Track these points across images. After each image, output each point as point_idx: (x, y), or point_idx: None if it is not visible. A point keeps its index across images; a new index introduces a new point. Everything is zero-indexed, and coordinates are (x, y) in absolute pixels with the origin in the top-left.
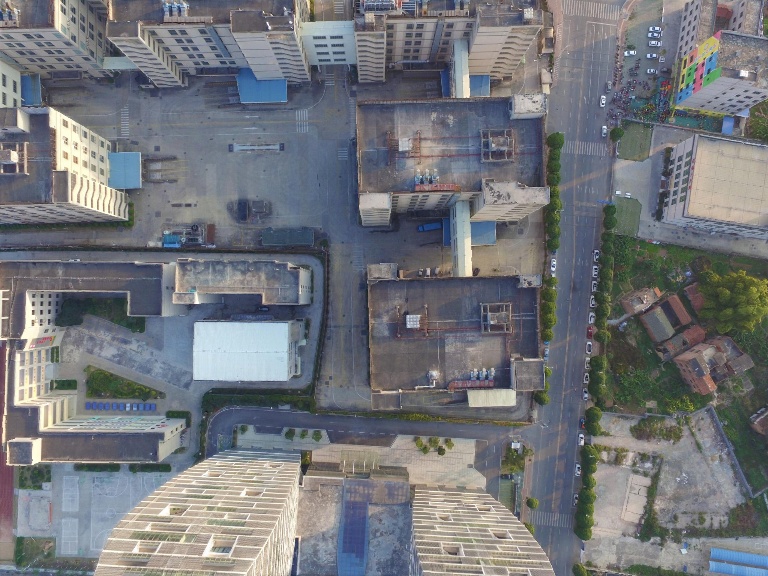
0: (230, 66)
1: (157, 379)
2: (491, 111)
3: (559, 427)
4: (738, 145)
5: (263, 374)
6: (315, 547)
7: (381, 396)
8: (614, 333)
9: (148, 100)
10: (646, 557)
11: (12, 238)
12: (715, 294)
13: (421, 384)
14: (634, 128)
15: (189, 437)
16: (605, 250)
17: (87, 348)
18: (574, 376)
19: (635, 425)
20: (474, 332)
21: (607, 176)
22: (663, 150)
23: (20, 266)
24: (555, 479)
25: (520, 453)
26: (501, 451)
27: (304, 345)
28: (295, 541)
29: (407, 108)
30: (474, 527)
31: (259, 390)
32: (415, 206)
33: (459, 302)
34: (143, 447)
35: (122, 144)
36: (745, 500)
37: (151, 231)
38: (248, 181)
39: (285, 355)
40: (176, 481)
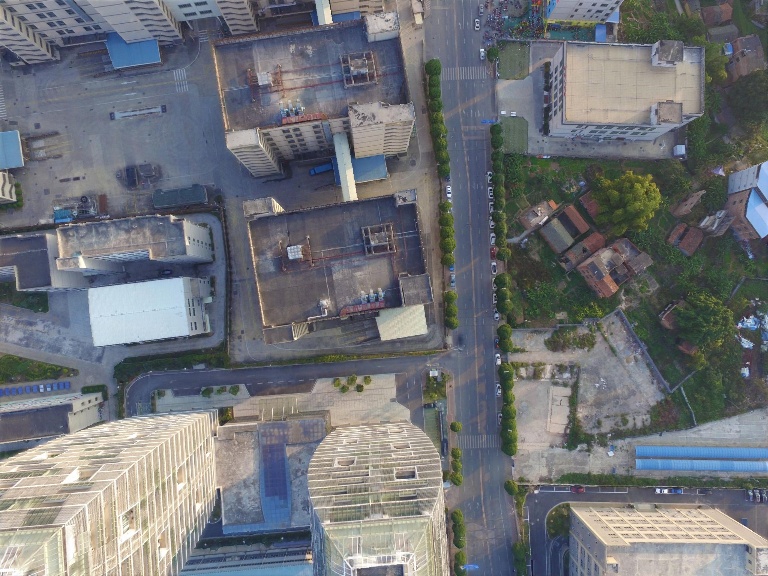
0: (97, 32)
1: (68, 357)
2: (349, 37)
3: (475, 350)
4: (607, 47)
5: (164, 331)
6: (238, 495)
7: (273, 330)
8: (516, 250)
9: (22, 78)
10: (575, 465)
11: None
12: (608, 199)
13: (313, 315)
14: (511, 47)
15: (108, 410)
16: (495, 169)
17: None
18: (483, 298)
19: (549, 338)
20: (359, 256)
21: (491, 98)
22: (542, 65)
23: None
24: (478, 402)
25: (440, 380)
26: (421, 381)
27: (212, 303)
28: (217, 492)
29: (265, 44)
30: (376, 444)
31: (172, 354)
32: (298, 147)
33: (341, 229)
34: (53, 421)
35: (1, 126)
36: (664, 396)
37: (42, 209)
38: (134, 147)
39: (183, 309)
40: (67, 437)
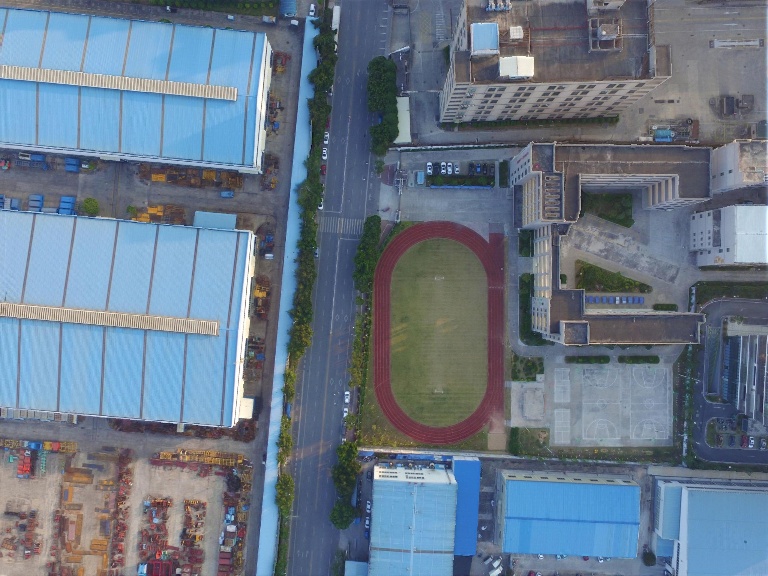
0: None
1: (643, 273)
2: None
3: None
4: None
5: None
6: None
7: None
8: None
9: None
10: None
11: (499, 135)
12: None
13: None
14: None
15: None
16: None
17: (575, 243)
18: None
19: None
20: None
21: None
22: None
23: (570, 151)
24: None
25: None
26: None
27: None
28: None
29: None
30: None
31: (744, 283)
32: None
33: None
34: (681, 329)
35: None
36: None
37: (635, 127)
38: (729, 77)
39: None
40: None
